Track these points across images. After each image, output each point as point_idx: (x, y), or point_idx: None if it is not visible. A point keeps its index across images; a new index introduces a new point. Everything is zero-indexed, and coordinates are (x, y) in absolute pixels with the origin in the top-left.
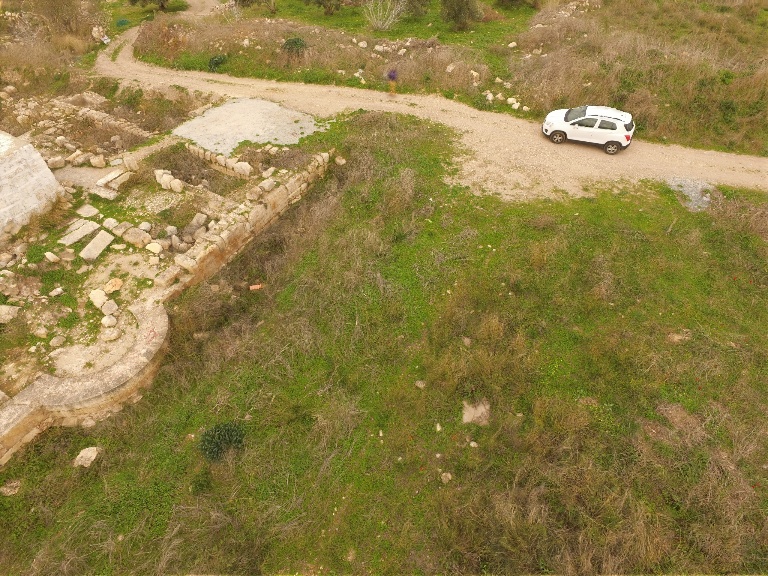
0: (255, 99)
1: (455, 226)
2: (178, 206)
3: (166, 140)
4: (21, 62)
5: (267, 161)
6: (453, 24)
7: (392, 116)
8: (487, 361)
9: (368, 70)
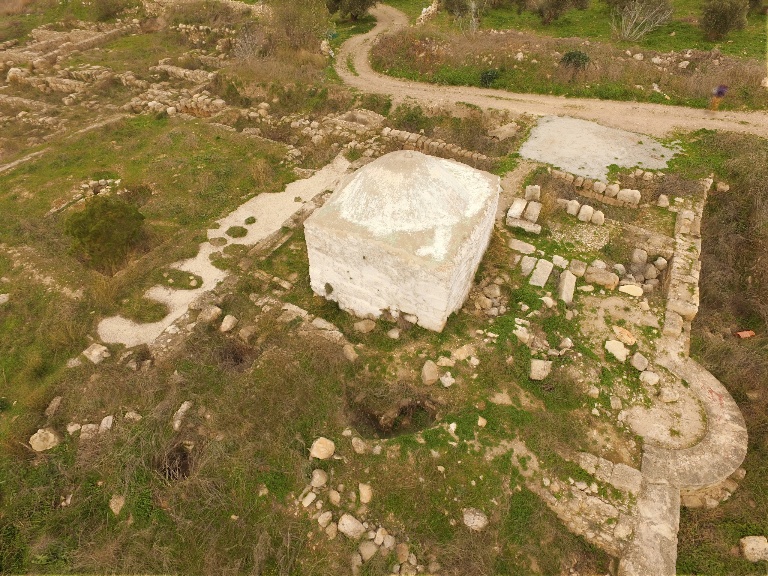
0: (566, 117)
1: None
2: (610, 241)
3: (523, 164)
4: (267, 78)
5: (640, 187)
6: (699, 33)
7: (754, 137)
8: None
9: (664, 85)
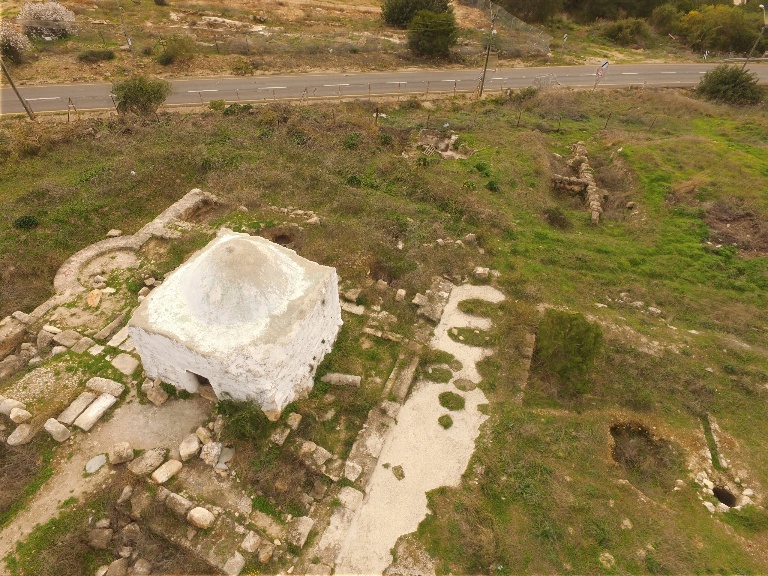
0: None
1: None
2: None
3: (1, 552)
4: None
5: None
6: None
7: None
8: None
9: None
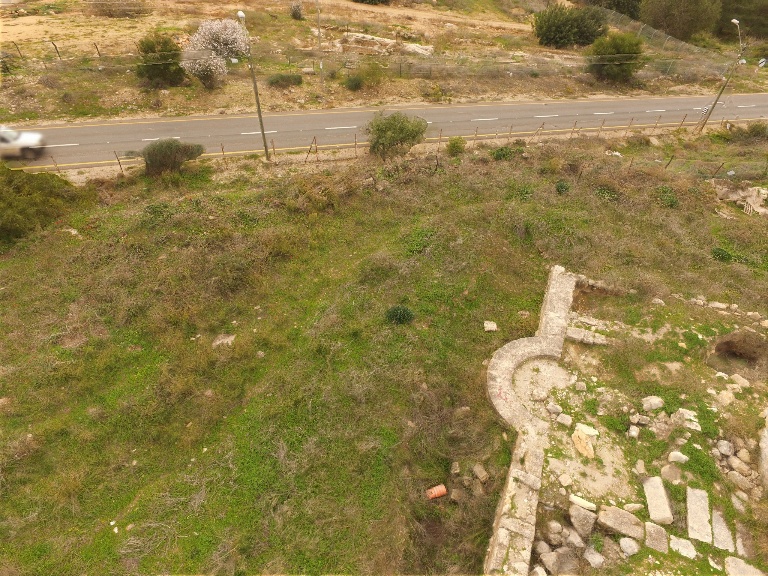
0: None
1: (149, 571)
2: None
3: None
4: None
5: None
6: None
7: None
8: (200, 363)
9: None
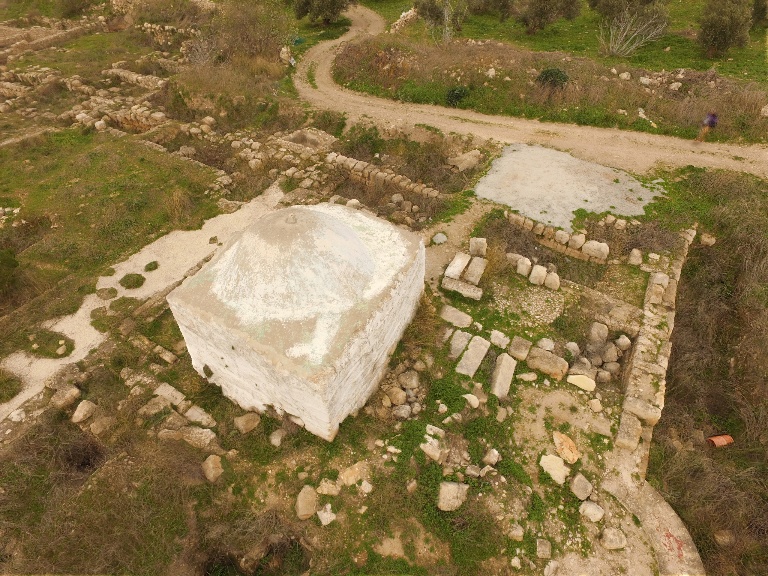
0: (535, 146)
1: None
2: (565, 311)
3: (476, 205)
4: (215, 88)
5: (611, 237)
6: (696, 49)
7: (748, 179)
8: None
9: (651, 110)
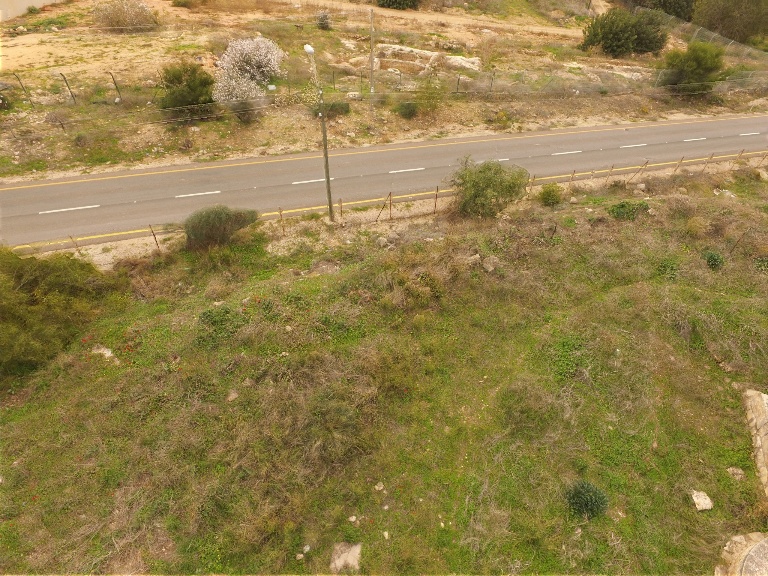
0: None
1: None
2: None
3: None
4: None
5: None
6: None
7: None
8: None
9: None
